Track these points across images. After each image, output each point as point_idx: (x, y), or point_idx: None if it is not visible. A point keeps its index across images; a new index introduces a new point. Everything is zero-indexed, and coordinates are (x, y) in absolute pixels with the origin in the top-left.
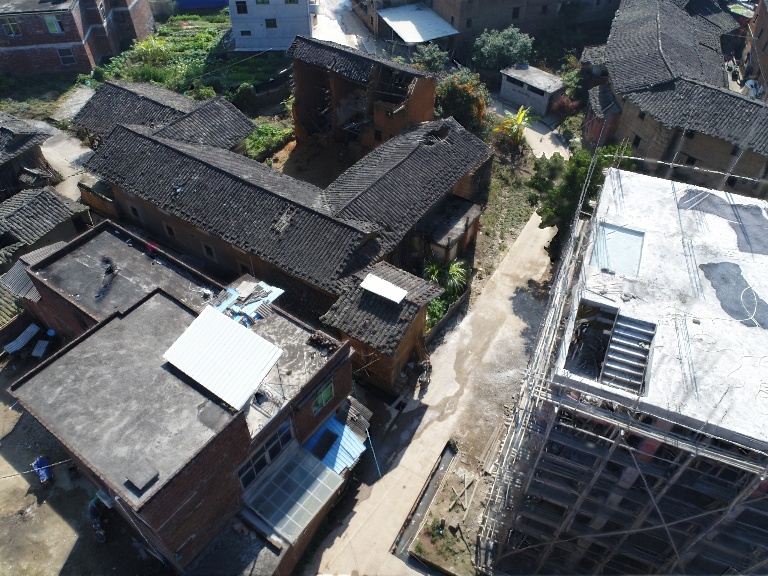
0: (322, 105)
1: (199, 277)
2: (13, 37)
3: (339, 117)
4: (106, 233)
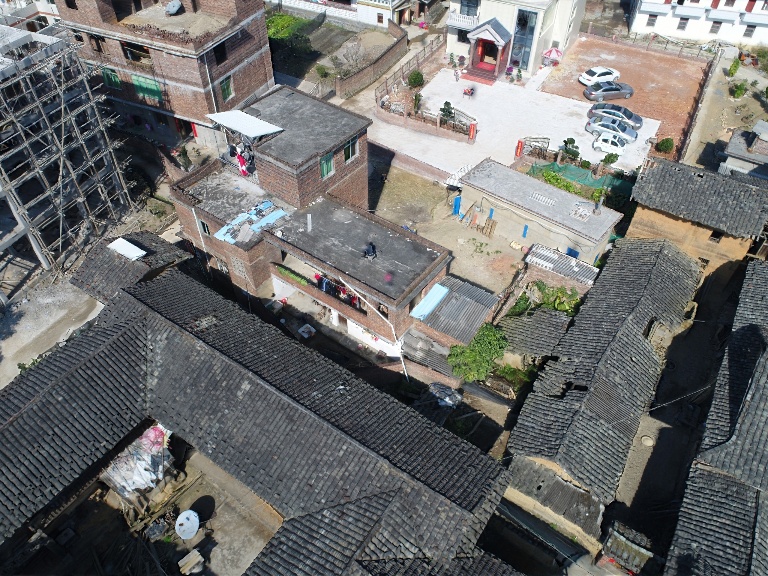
0: None
1: None
2: None
3: None
4: (394, 296)
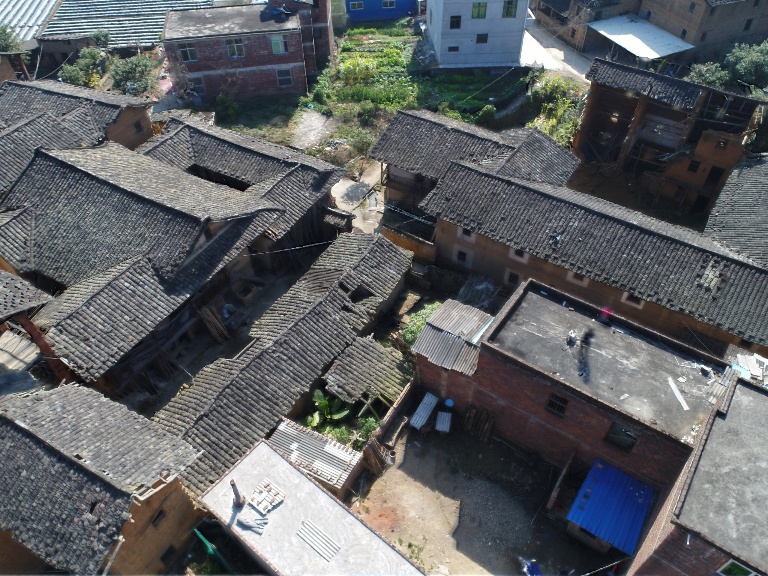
0: (605, 131)
1: (682, 349)
2: (236, 58)
3: (630, 145)
4: (533, 294)
